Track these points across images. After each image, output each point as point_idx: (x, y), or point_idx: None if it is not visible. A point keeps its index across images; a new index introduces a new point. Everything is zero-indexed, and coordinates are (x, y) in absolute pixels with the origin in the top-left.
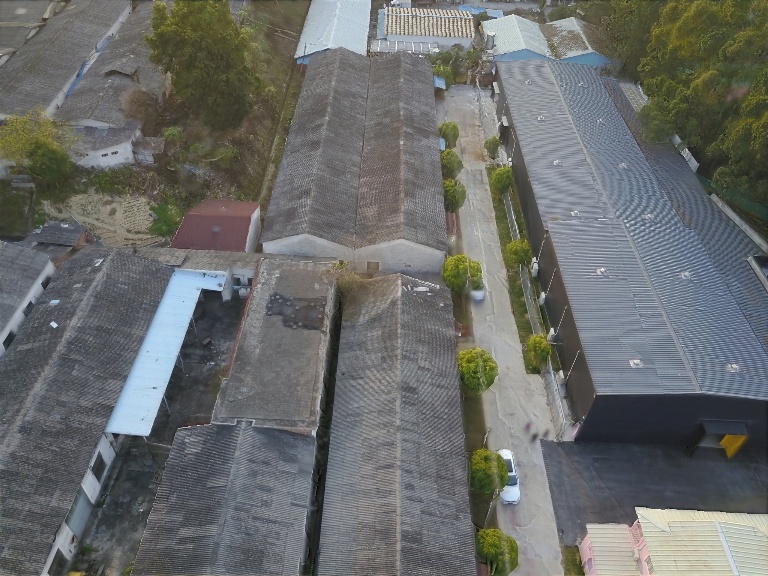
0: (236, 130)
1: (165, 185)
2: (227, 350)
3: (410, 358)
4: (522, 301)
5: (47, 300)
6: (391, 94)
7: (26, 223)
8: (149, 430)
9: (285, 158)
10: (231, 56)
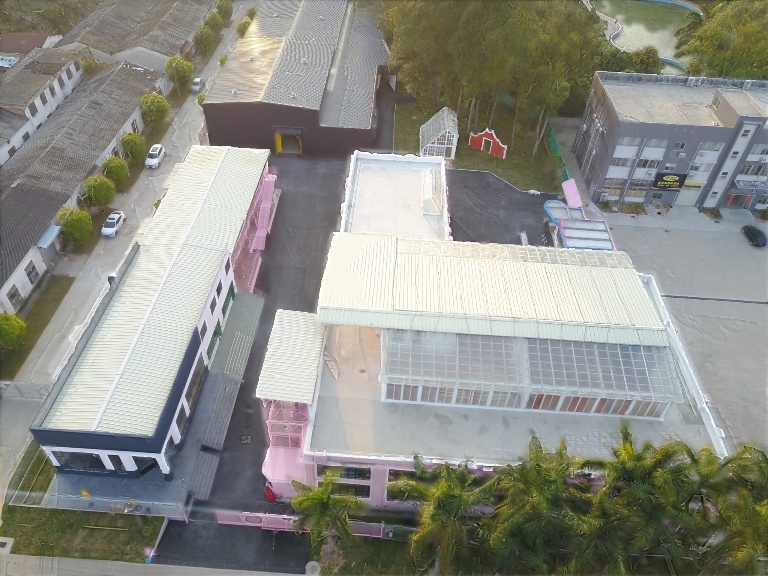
0: None
1: None
2: None
3: (106, 92)
4: None
5: None
6: None
7: None
8: None
9: (92, 12)
10: None
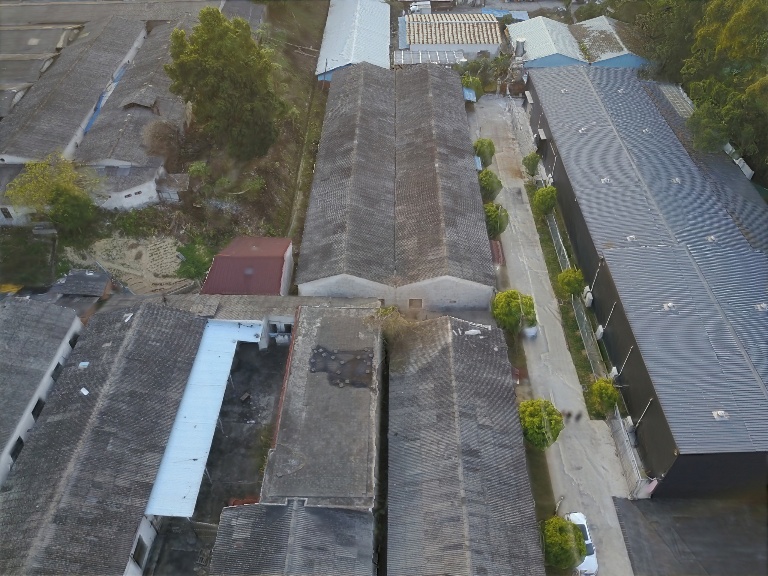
0: (261, 158)
1: (191, 224)
2: (267, 406)
3: (468, 415)
4: (577, 335)
5: (76, 362)
6: (420, 111)
7: (49, 272)
8: (192, 510)
9: (315, 187)
10: (254, 83)
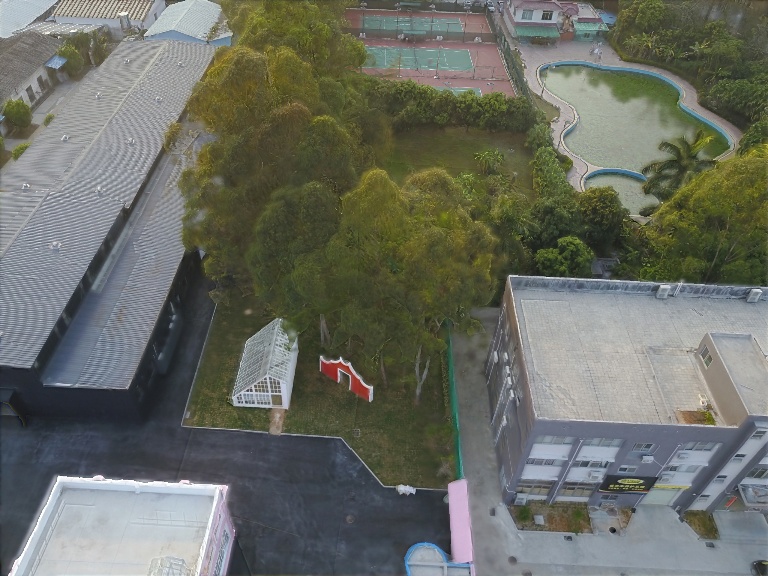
0: None
1: None
2: None
3: None
4: None
5: None
6: None
7: None
8: None
9: None
10: None
